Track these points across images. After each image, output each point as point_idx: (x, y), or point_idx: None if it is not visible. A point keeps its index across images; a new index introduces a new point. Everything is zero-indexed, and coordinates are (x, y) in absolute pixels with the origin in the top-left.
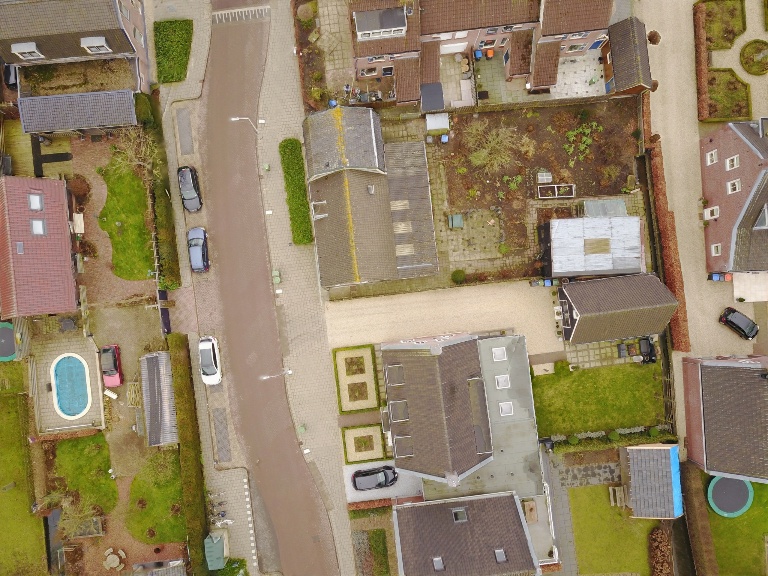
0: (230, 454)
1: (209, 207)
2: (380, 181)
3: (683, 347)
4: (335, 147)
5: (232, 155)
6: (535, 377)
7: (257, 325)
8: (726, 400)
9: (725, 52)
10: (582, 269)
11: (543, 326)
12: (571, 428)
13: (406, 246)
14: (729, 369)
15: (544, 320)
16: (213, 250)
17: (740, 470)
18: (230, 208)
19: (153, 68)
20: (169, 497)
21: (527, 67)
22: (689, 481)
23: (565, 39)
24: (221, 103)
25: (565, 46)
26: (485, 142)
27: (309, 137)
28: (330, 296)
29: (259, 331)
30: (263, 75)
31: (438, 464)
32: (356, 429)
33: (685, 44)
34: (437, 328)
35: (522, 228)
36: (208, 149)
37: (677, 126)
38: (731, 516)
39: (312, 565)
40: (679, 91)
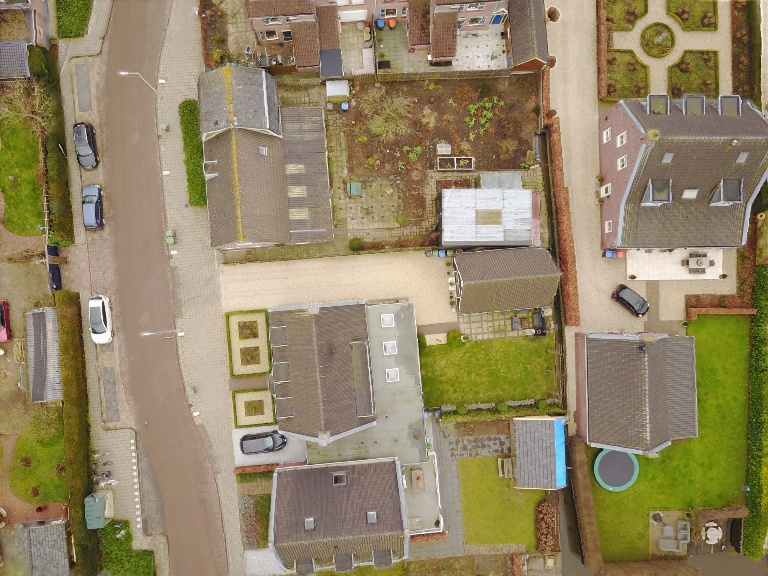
0: (118, 415)
1: (106, 165)
2: (274, 144)
3: (573, 321)
4: (224, 105)
5: (131, 114)
6: (428, 347)
7: (150, 285)
8: (608, 372)
9: (626, 33)
10: (473, 239)
11: (438, 297)
12: (462, 399)
13: (300, 210)
14: (611, 342)
15: (439, 291)
16: (109, 209)
17: (618, 441)
18: (127, 167)
19: (53, 23)
20: (54, 456)
21: (427, 38)
22: (574, 454)
23: (462, 10)
24: (121, 61)
25: (464, 18)
26: (380, 109)
27: (200, 95)
28: (226, 259)
29: (152, 292)
30: (165, 35)
31: (313, 424)
32: (247, 393)
33: (587, 24)
34: (332, 295)
35: (421, 199)
36: (107, 107)
37: (577, 104)
38: (616, 490)
39: (197, 528)
40: (580, 70)
